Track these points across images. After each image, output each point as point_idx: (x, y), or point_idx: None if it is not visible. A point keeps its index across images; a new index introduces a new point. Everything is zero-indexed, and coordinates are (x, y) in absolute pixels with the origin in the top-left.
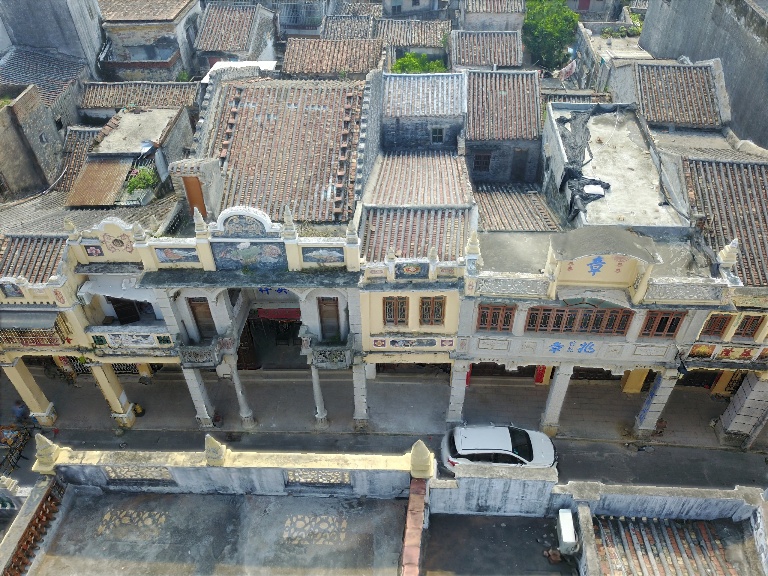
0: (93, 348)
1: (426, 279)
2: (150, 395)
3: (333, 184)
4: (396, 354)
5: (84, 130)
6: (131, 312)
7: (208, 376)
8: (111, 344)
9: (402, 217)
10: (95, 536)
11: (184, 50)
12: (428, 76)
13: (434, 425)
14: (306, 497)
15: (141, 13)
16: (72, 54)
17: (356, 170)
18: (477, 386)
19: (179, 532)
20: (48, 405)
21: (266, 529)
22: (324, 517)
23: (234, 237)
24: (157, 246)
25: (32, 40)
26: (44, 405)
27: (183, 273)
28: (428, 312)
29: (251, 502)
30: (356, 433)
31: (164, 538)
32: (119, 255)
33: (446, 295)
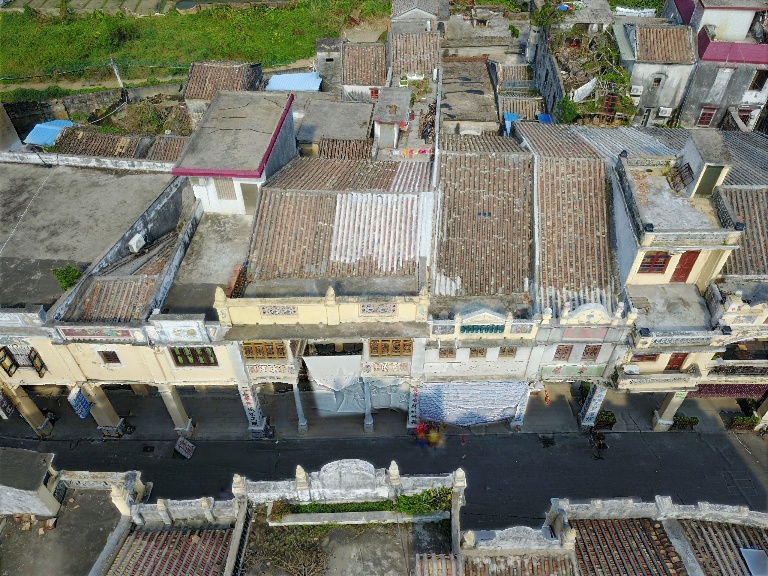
0: None
1: None
2: None
3: None
4: None
5: None
6: None
7: None
8: None
9: None
10: None
11: None
12: None
13: None
14: None
15: None
16: None
17: None
18: None
19: None
20: None
21: None
22: None
23: None
24: None
25: None
26: None
27: None
28: None
29: None
30: None
31: None
32: None
33: None
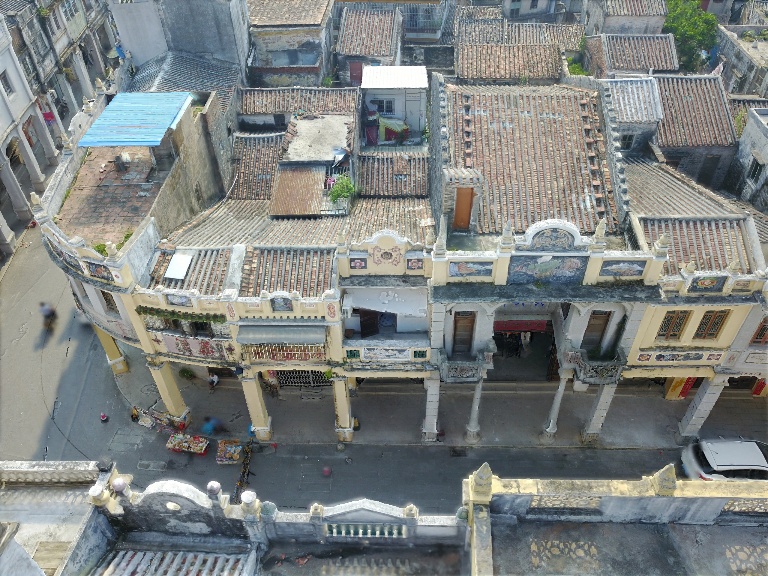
0: (344, 362)
1: (719, 293)
2: (360, 408)
3: (589, 194)
4: (657, 368)
5: (250, 137)
6: (373, 325)
7: (414, 388)
8: (363, 358)
9: (675, 228)
10: (533, 568)
11: (324, 55)
12: (616, 81)
13: (662, 439)
14: (733, 526)
15: (285, 17)
16: (226, 59)
17: (612, 180)
18: (693, 398)
19: (620, 564)
20: (268, 419)
21: (710, 561)
22: (763, 548)
23: (539, 251)
24: (454, 260)
25: (189, 45)
26: (266, 419)
27: (473, 287)
28: (705, 326)
29: (677, 531)
30: (583, 447)
31: (607, 571)
32: (383, 268)
33: (734, 309)
